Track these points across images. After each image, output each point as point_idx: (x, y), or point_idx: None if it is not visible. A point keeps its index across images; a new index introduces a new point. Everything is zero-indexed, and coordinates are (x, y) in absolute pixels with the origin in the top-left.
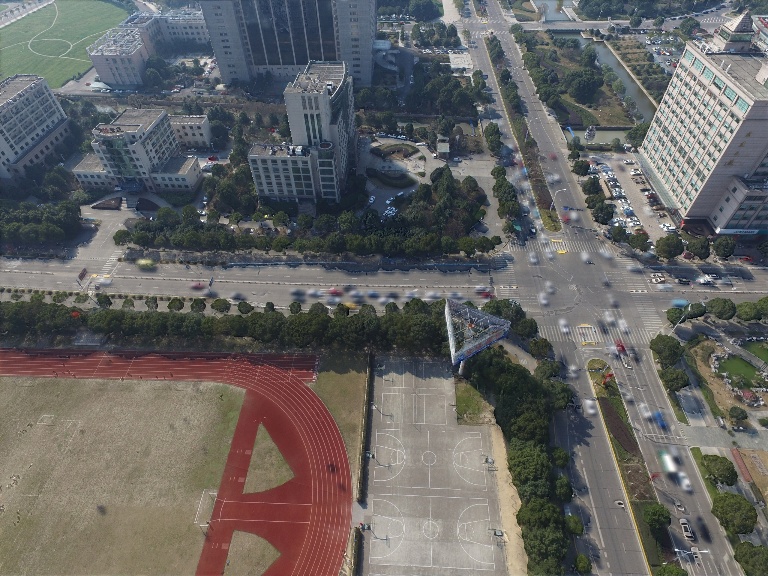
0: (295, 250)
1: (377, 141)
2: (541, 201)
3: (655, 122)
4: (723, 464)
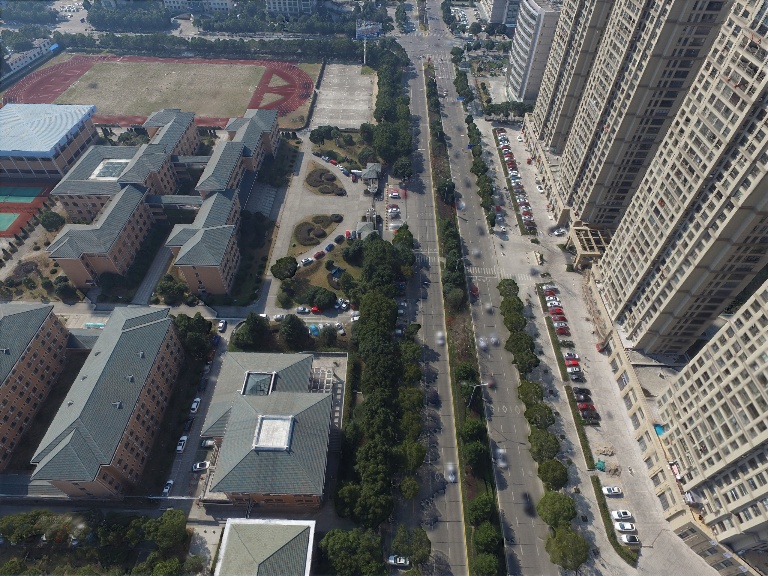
0: (288, 33)
1: (335, 0)
2: (421, 21)
3: None
4: None
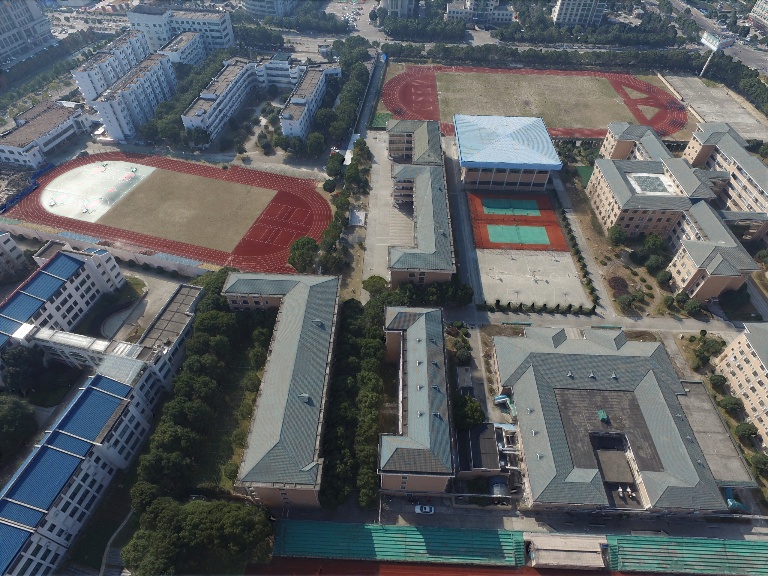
0: (587, 44)
1: None
2: None
3: None
4: None
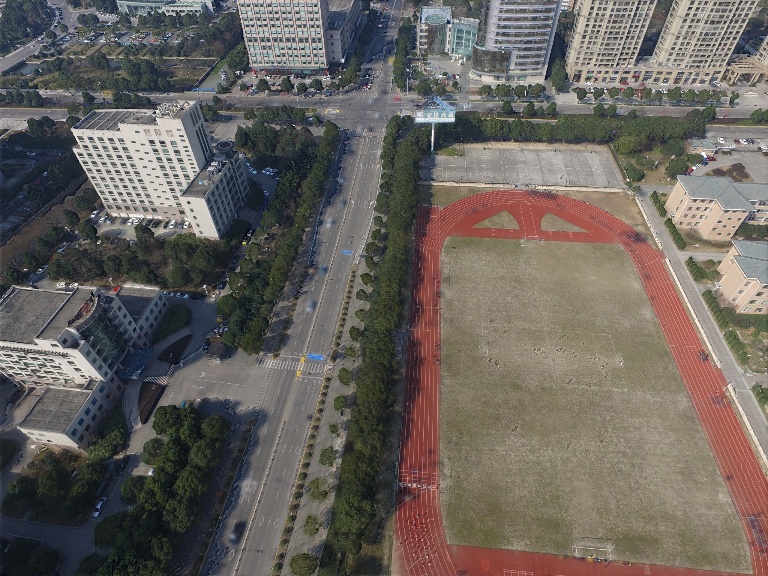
0: None
1: None
2: None
3: (249, 42)
4: (485, 86)
